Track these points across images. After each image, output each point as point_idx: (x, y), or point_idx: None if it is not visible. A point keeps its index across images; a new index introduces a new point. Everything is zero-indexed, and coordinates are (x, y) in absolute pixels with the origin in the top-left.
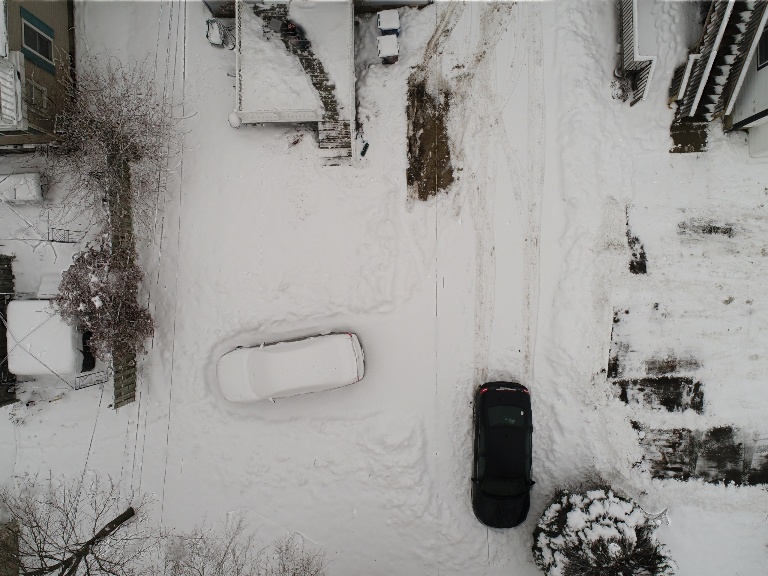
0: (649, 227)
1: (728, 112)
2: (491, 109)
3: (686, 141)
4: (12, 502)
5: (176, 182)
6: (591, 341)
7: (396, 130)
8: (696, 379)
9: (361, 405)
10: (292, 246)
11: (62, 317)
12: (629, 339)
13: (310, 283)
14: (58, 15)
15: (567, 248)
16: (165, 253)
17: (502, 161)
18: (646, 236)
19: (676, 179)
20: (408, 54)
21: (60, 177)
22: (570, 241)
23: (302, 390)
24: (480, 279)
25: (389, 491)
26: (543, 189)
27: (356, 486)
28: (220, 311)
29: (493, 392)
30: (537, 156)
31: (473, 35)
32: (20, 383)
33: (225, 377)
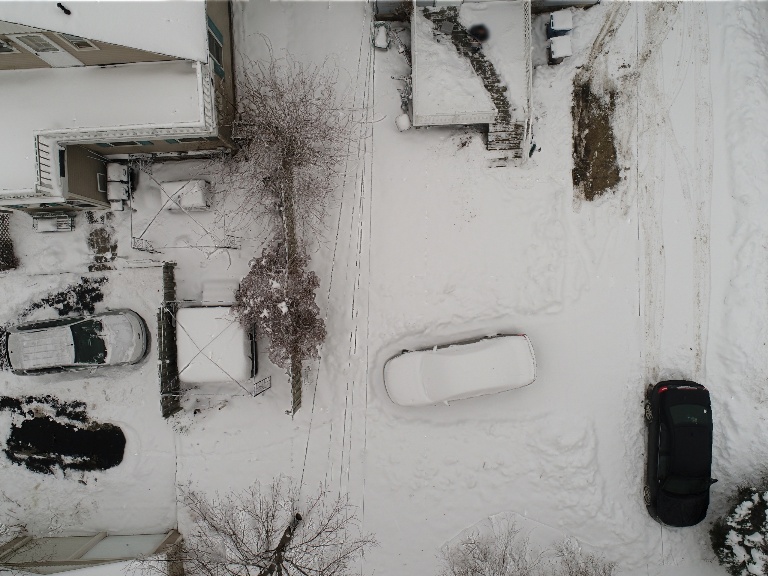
0: None
1: None
2: (658, 108)
3: None
4: (211, 511)
5: None
6: (767, 338)
7: (562, 131)
8: None
9: (529, 406)
10: (457, 248)
11: (240, 324)
12: None
13: (476, 285)
14: (224, 21)
15: (738, 245)
16: (327, 258)
17: (670, 160)
18: None
19: None
20: (574, 54)
21: (240, 183)
22: (741, 238)
23: (479, 392)
24: (649, 278)
25: (561, 492)
26: (712, 187)
27: (527, 487)
28: (384, 315)
29: (675, 391)
30: (705, 154)
31: (639, 34)
32: (187, 391)
33: (396, 381)
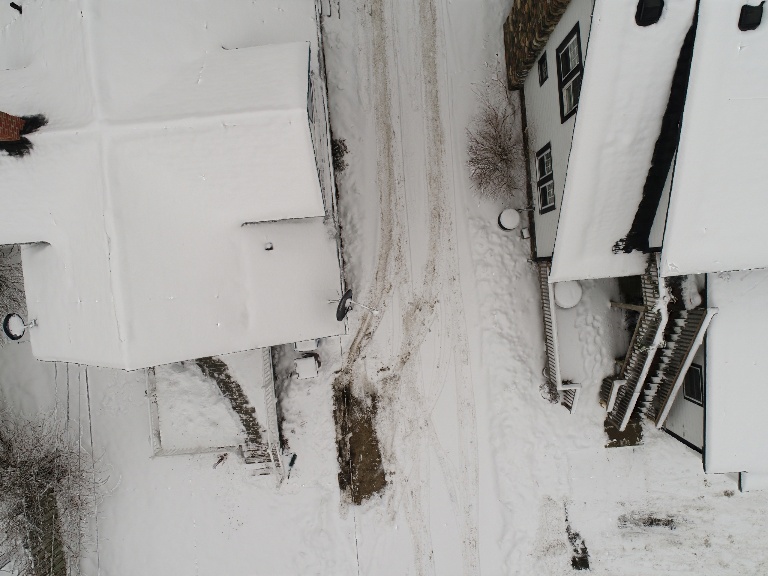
0: (589, 523)
1: (659, 427)
2: (420, 411)
3: (621, 435)
4: None
5: None
6: None
7: (324, 436)
8: None
9: None
10: (227, 555)
11: None
12: None
13: None
14: None
15: (506, 550)
16: None
17: (435, 464)
18: (586, 532)
19: (613, 473)
20: (330, 360)
21: None
22: (509, 543)
23: None
24: None
25: None
26: (478, 490)
27: None
28: None
29: None
30: (470, 456)
31: (396, 337)
32: None
33: None
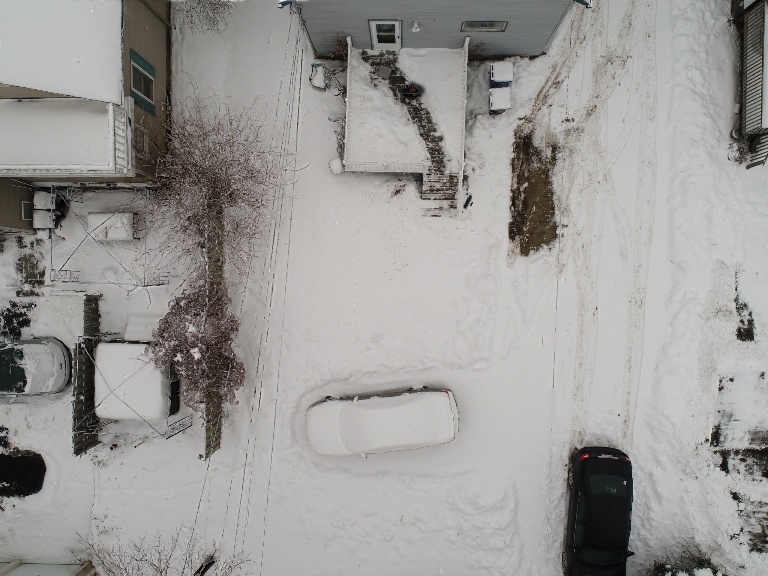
0: (759, 294)
1: None
2: (600, 165)
3: None
4: (107, 558)
5: None
6: (696, 410)
7: (500, 183)
8: None
9: (451, 462)
10: (387, 297)
11: (155, 365)
12: (733, 408)
13: (404, 335)
14: (159, 52)
15: (673, 312)
16: (255, 298)
17: (609, 219)
18: (755, 303)
19: None
20: (516, 105)
21: (161, 223)
22: (677, 305)
23: (397, 448)
24: (581, 339)
25: (478, 552)
26: (651, 250)
27: (443, 545)
28: (310, 360)
29: (595, 460)
30: (646, 215)
31: (585, 88)
32: (104, 426)
33: (315, 429)
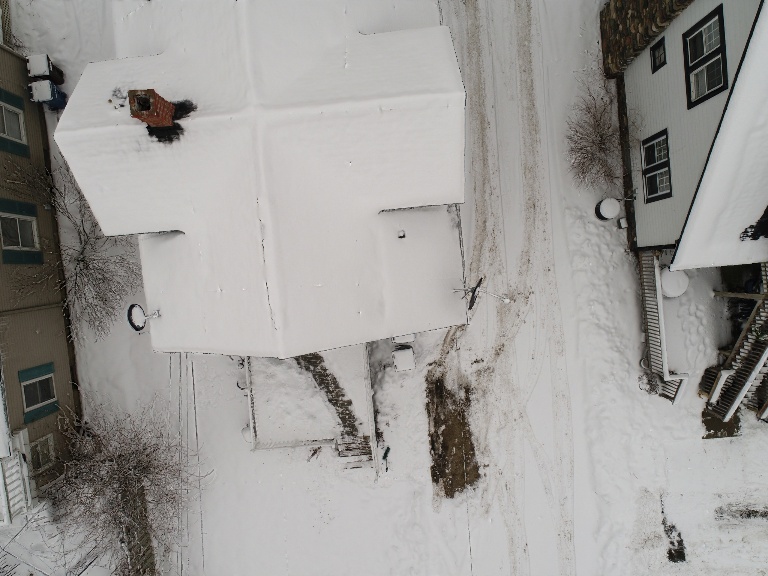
0: (685, 515)
1: (764, 417)
2: (514, 403)
3: (719, 426)
4: None
5: None
6: None
7: (417, 429)
8: None
9: None
10: (318, 549)
11: None
12: None
13: None
14: (56, 341)
15: (602, 543)
16: None
17: (529, 456)
18: (683, 524)
19: (710, 464)
20: (424, 352)
21: (74, 529)
22: (605, 536)
23: None
24: None
25: None
26: (574, 483)
27: None
28: None
29: None
30: (565, 448)
31: (490, 328)
32: None
33: None
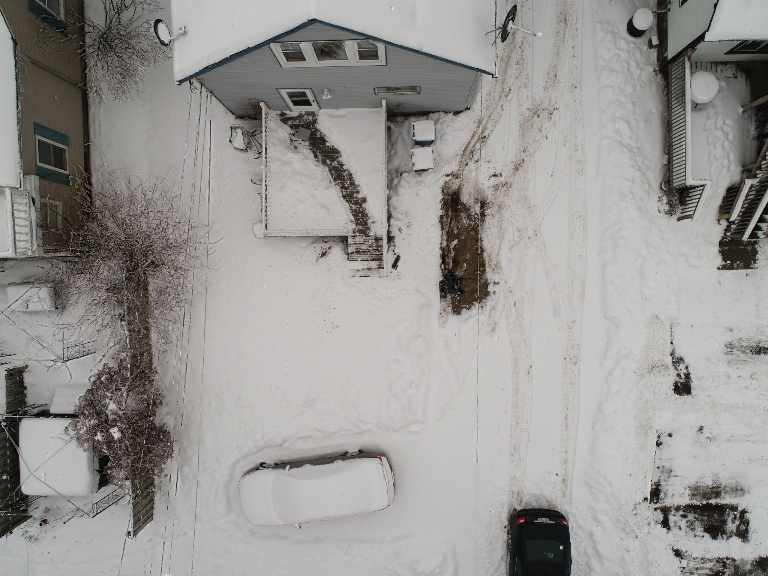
0: (695, 347)
1: None
2: (530, 220)
3: (735, 257)
4: None
5: (196, 290)
6: (633, 469)
7: (429, 241)
8: (742, 506)
9: (390, 526)
10: (318, 359)
11: (78, 442)
12: (672, 463)
13: (337, 399)
14: (73, 118)
15: (608, 368)
16: (184, 364)
17: (541, 275)
18: (691, 356)
19: (724, 297)
20: (442, 161)
21: (76, 298)
22: (612, 361)
23: (330, 518)
24: (516, 398)
25: None
26: (584, 306)
27: None
28: (242, 426)
29: (531, 525)
30: (578, 270)
31: (511, 142)
32: (33, 501)
33: (248, 499)
